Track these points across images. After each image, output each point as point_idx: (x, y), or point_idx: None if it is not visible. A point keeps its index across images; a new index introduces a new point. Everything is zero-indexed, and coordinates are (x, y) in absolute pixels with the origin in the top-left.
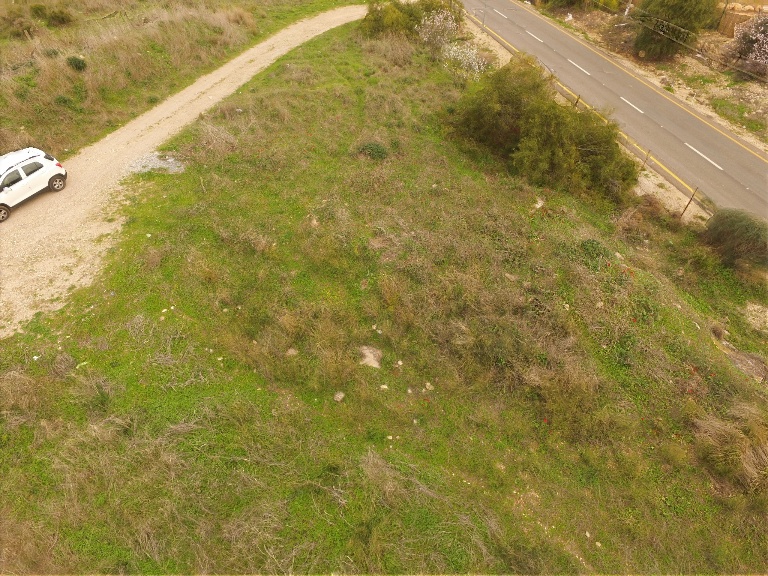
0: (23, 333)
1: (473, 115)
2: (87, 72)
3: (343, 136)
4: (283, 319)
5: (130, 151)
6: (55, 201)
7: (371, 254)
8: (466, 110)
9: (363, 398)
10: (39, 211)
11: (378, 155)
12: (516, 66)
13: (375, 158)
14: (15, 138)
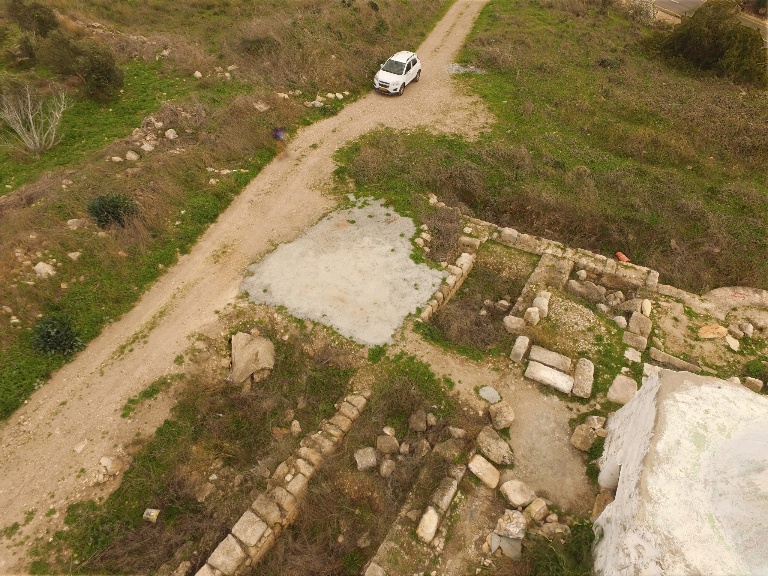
0: (483, 140)
1: (681, 38)
2: (380, 13)
3: (579, 56)
4: (638, 133)
5: (437, 63)
6: (420, 87)
7: (657, 111)
8: (670, 37)
9: (707, 166)
10: (417, 91)
11: (615, 66)
12: (715, 3)
13: (613, 68)
14: (376, 49)
